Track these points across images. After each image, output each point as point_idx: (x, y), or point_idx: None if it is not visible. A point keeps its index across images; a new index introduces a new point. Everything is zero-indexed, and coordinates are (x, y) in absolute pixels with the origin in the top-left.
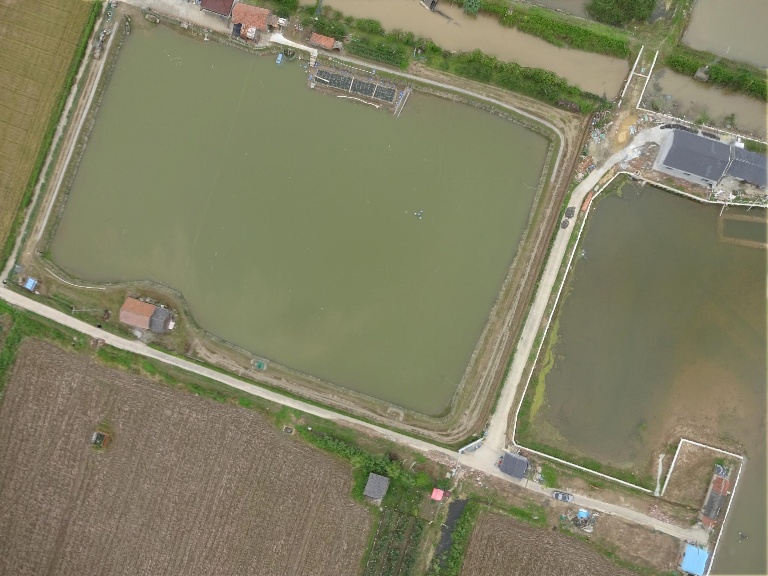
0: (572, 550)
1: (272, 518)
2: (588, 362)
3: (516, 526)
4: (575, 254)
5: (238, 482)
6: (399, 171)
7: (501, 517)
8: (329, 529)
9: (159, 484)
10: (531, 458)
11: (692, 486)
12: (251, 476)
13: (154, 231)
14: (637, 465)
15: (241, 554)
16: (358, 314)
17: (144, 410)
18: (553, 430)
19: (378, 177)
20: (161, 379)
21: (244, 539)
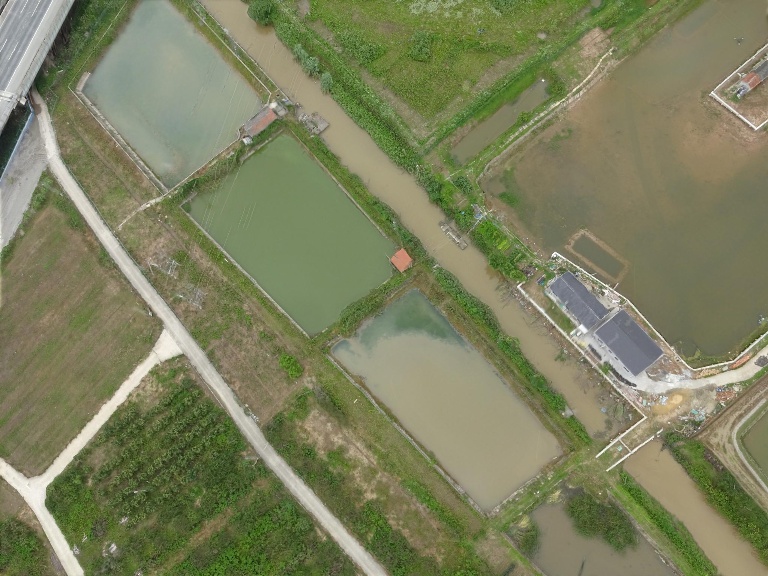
0: None
1: None
2: None
3: None
4: None
5: None
6: None
7: None
8: None
9: None
10: None
11: None
12: None
13: None
14: None
15: None
16: None
17: None
18: None
19: None
20: None
21: None
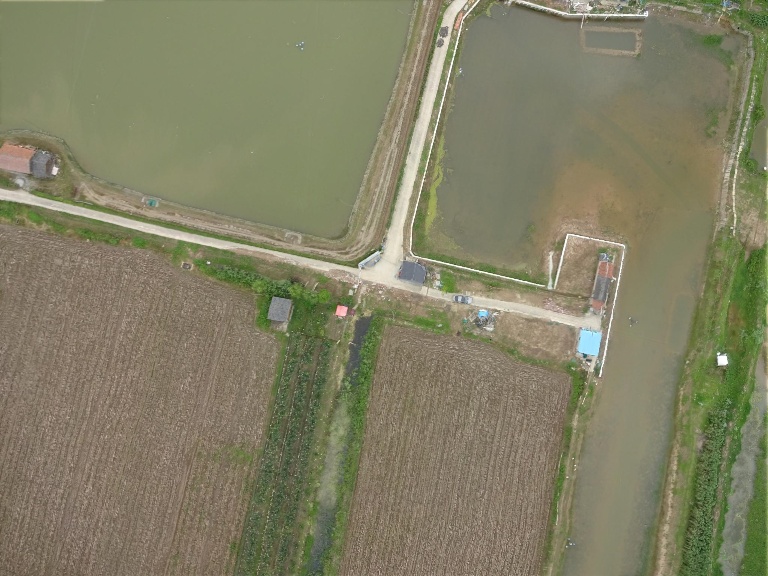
0: (477, 352)
1: (177, 357)
2: (475, 173)
3: (422, 336)
4: (453, 72)
5: (138, 324)
6: (277, 6)
7: (406, 329)
8: (236, 360)
9: (54, 336)
10: (429, 266)
11: (581, 276)
12: (151, 317)
13: (30, 79)
14: (530, 265)
15: (147, 397)
16: (248, 146)
17: (32, 262)
18: (448, 240)
19: (257, 13)
20: (48, 228)
21: (149, 381)
